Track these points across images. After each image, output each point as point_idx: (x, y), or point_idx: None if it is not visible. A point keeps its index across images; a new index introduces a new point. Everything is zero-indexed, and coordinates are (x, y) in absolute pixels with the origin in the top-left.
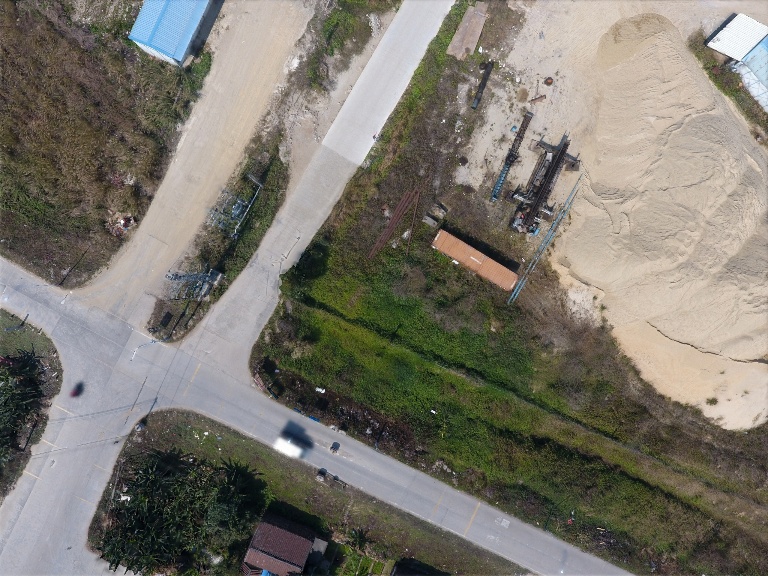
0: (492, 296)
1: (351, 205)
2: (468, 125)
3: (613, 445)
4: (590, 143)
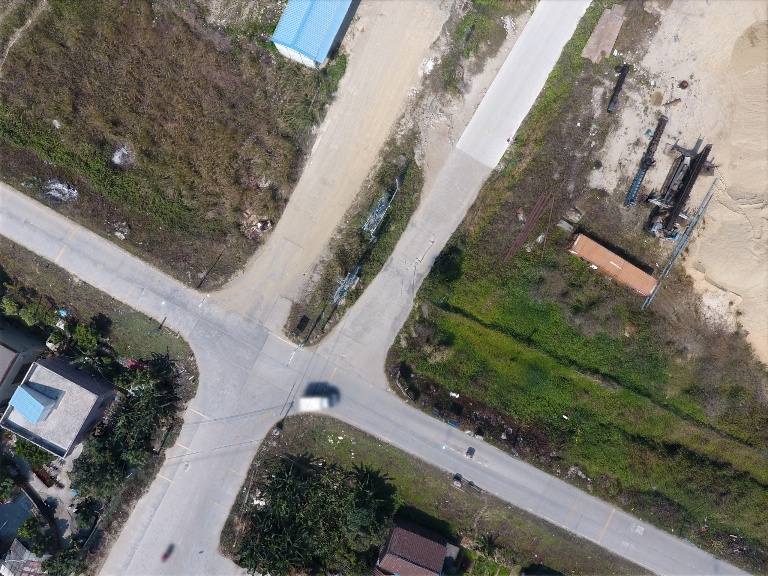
0: (627, 301)
1: (485, 209)
2: (603, 129)
3: (747, 452)
4: (724, 147)
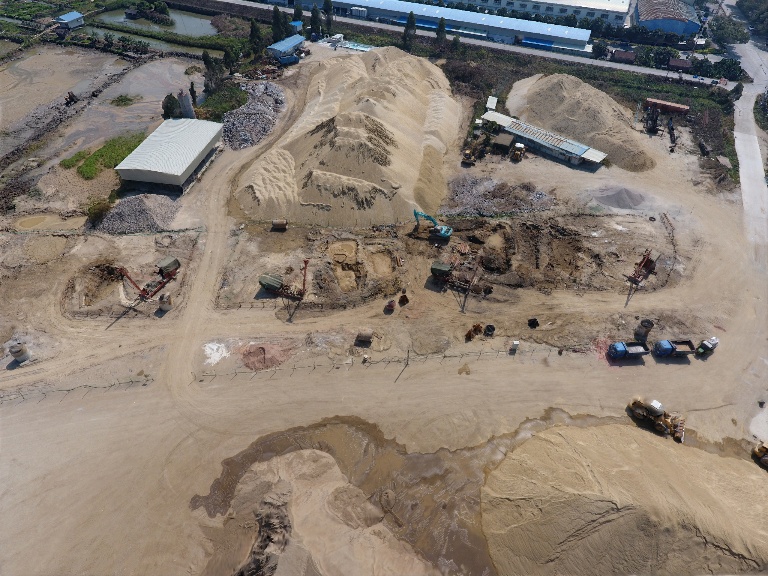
0: None
1: None
2: None
3: None
4: None
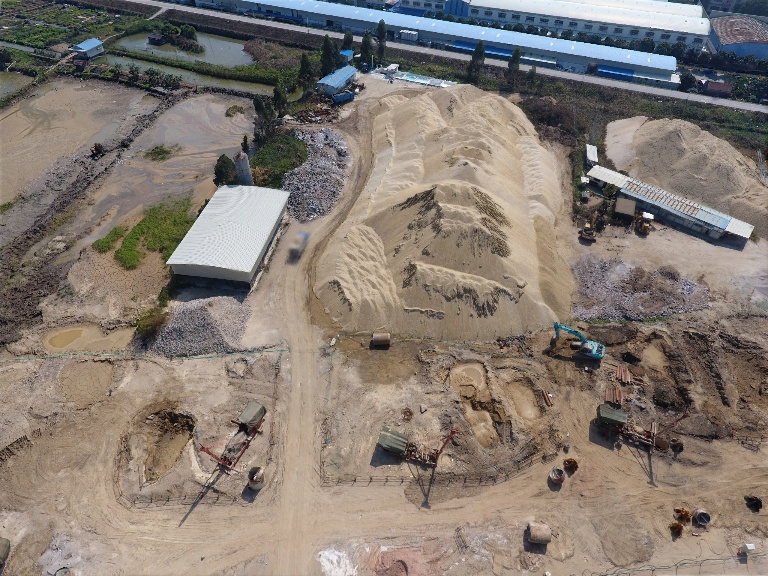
0: None
1: None
2: None
3: None
4: None
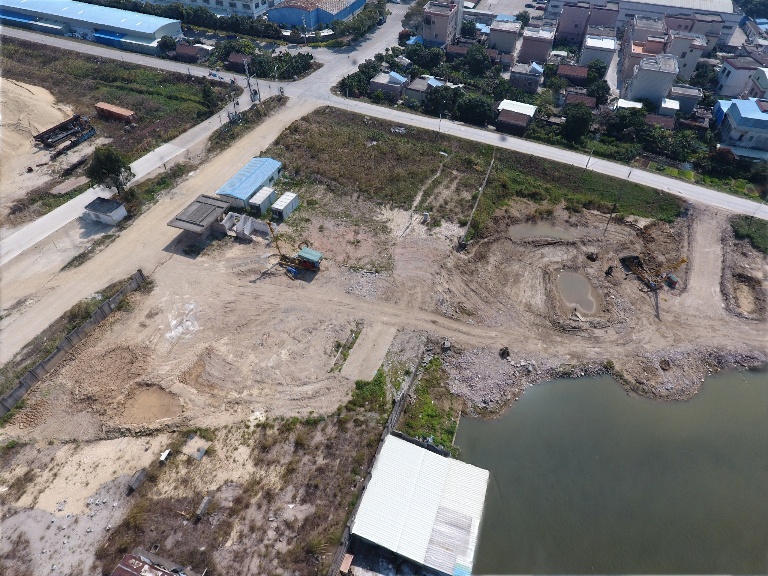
0: None
1: None
2: None
3: None
4: (20, 152)
